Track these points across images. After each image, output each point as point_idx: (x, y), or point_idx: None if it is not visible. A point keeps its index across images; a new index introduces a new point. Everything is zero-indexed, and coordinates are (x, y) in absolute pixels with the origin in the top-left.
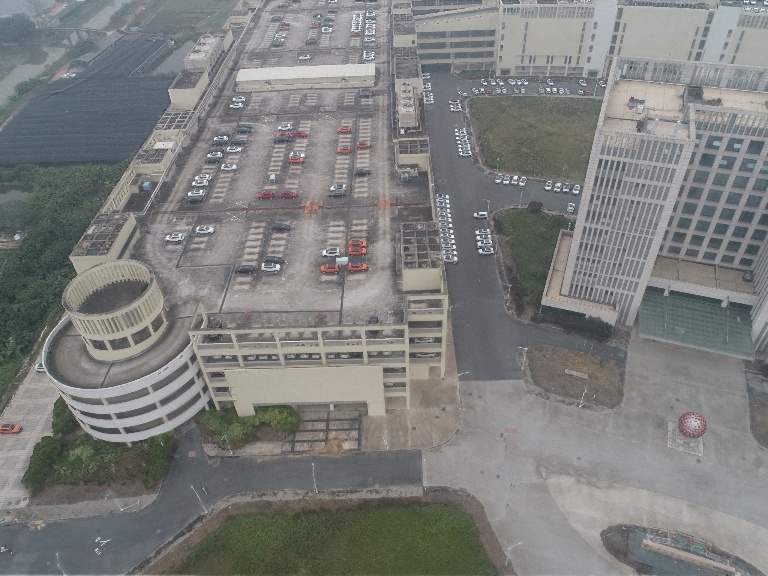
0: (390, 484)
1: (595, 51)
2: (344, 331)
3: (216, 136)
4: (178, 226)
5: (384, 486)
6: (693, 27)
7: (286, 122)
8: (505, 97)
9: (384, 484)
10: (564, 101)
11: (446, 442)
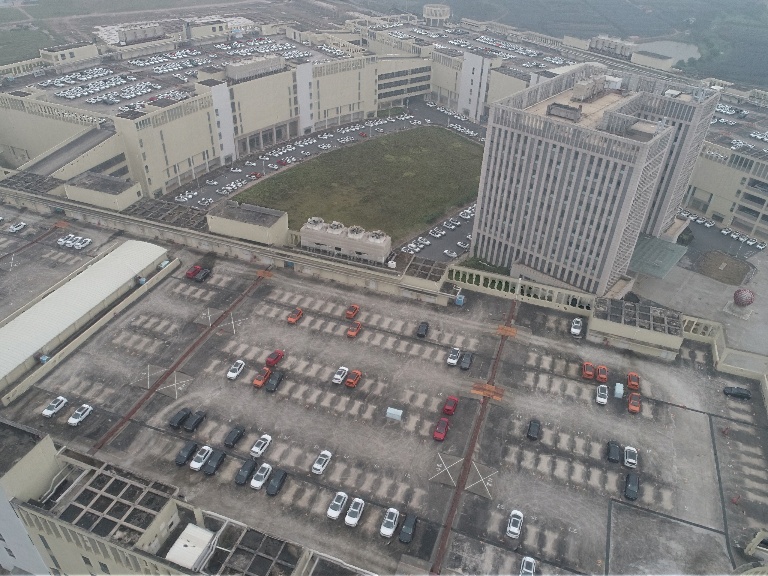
0: None
1: (224, 137)
2: (745, 419)
3: (183, 463)
4: (481, 567)
5: None
6: (286, 88)
7: (210, 366)
8: None
9: None
10: (260, 190)
11: None
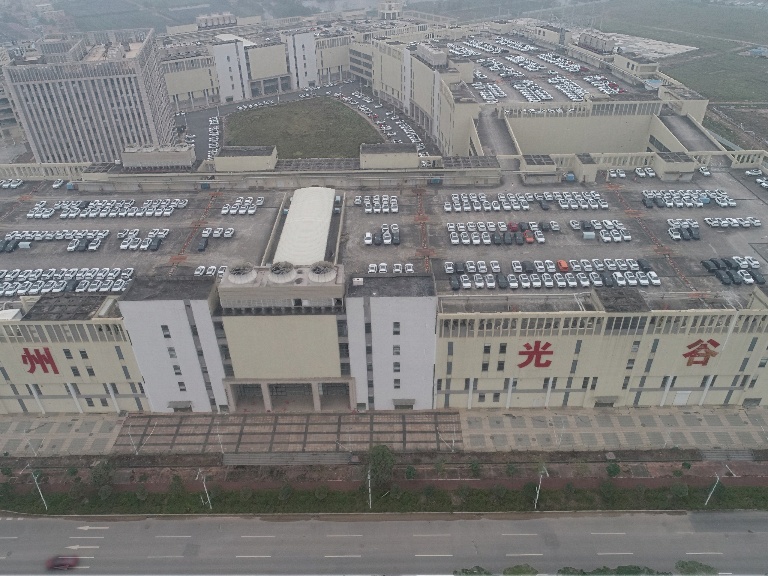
0: None
1: None
2: None
3: None
4: None
5: None
6: None
7: None
8: (335, 101)
9: None
10: None
11: None
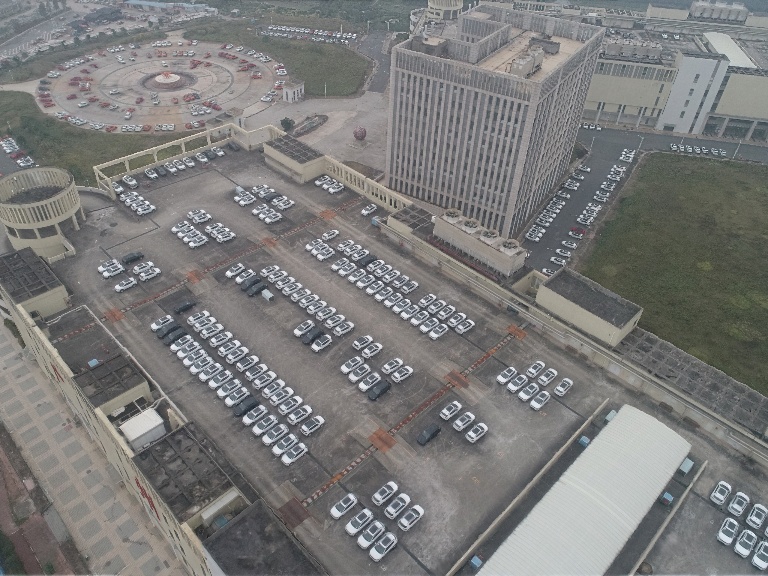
0: (370, 86)
1: None
2: None
3: None
4: None
5: (370, 85)
6: None
7: None
8: None
9: (371, 85)
10: None
11: (385, 97)
